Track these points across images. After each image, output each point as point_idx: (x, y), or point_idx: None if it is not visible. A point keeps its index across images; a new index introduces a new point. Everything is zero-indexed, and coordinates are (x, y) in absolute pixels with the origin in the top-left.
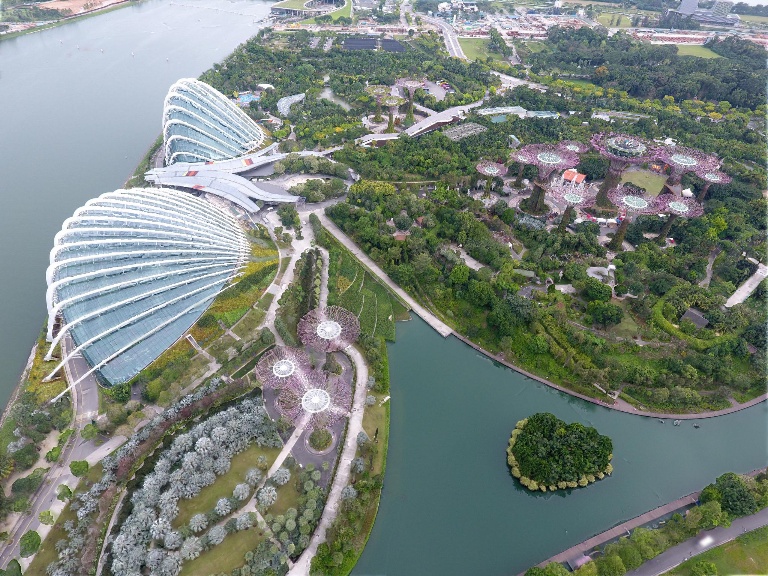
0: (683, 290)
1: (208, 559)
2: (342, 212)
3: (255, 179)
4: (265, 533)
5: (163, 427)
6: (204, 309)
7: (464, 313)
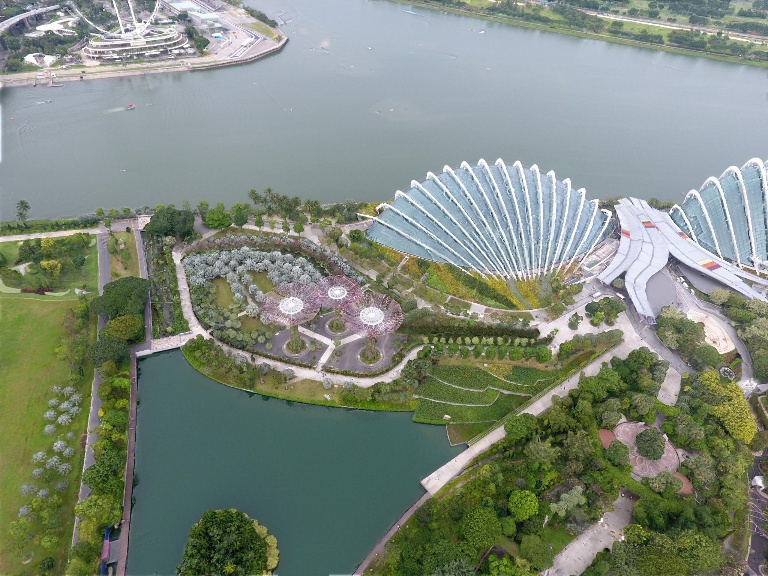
0: None
1: (228, 291)
2: (630, 357)
3: (682, 279)
4: (225, 308)
5: (319, 254)
6: (435, 259)
7: (453, 505)
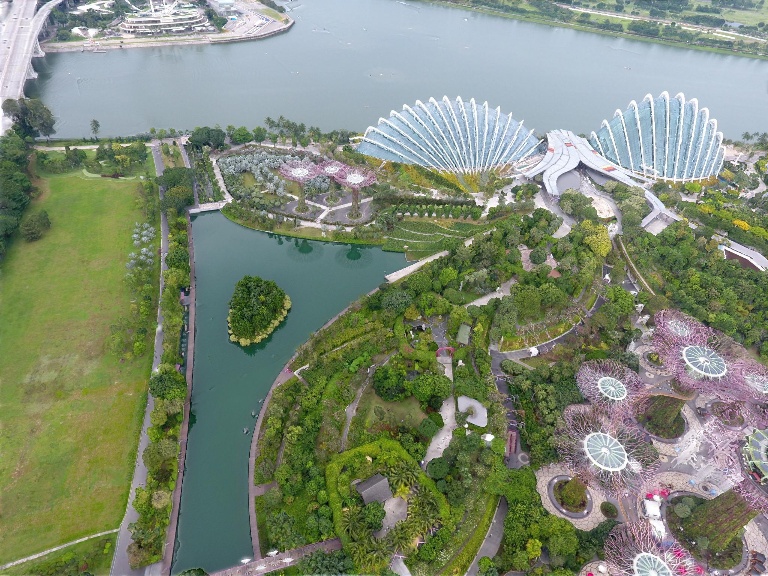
0: None
1: None
2: (534, 212)
3: (588, 178)
4: None
5: (319, 158)
6: (405, 162)
7: None
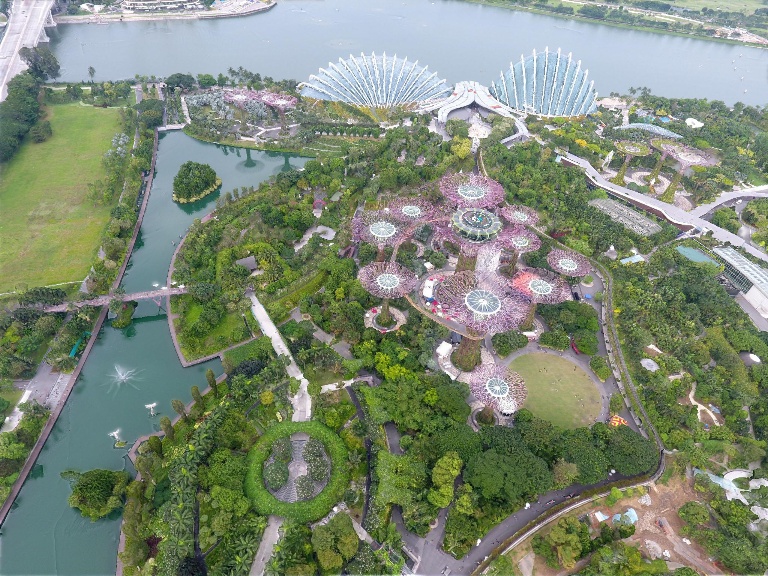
0: None
1: None
2: (419, 130)
3: (478, 114)
4: None
5: None
6: (333, 100)
7: None
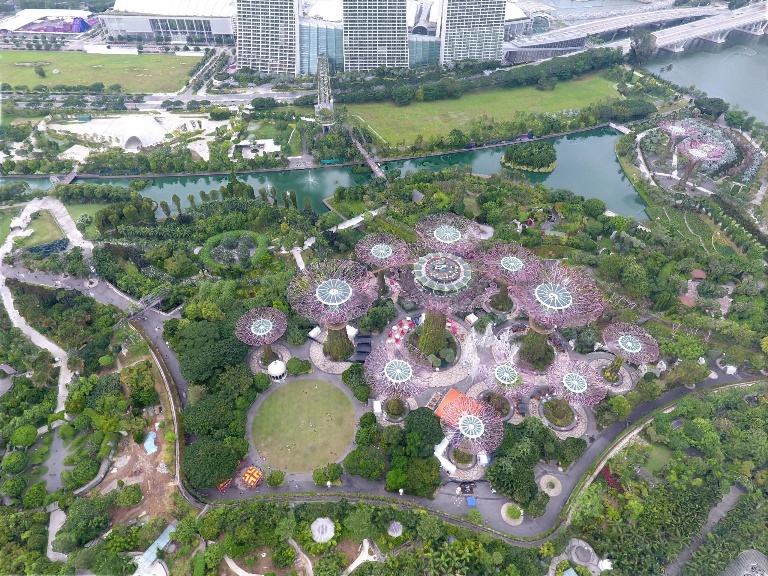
0: (419, 206)
1: None
2: None
3: None
4: None
5: None
6: None
7: None
